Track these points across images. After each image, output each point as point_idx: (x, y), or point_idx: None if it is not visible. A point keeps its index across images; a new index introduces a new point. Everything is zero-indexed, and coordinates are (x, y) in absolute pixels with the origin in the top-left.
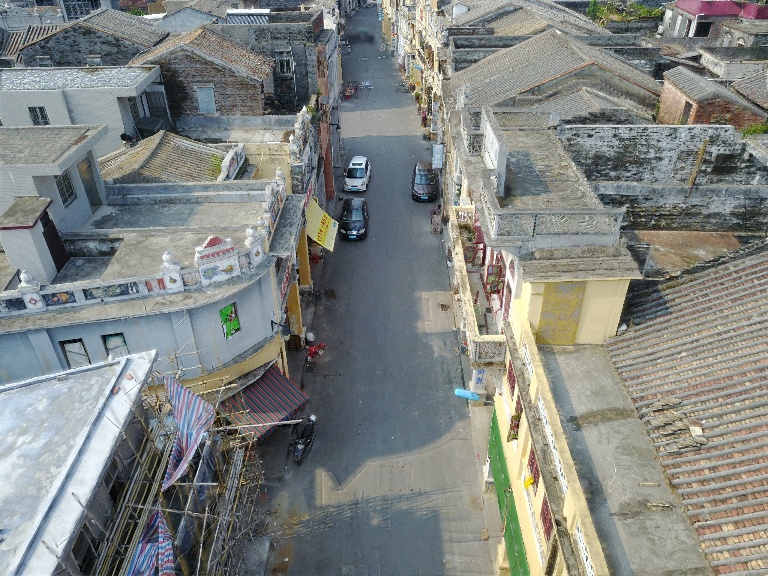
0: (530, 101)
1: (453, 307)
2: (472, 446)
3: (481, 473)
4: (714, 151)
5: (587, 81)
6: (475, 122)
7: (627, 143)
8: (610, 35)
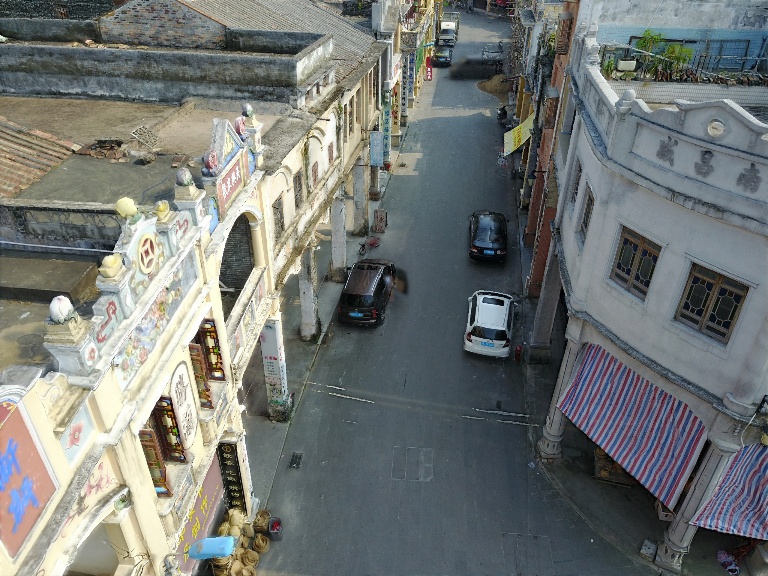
0: None
1: (395, 165)
2: (413, 117)
3: (413, 110)
4: None
5: None
6: None
7: None
8: None
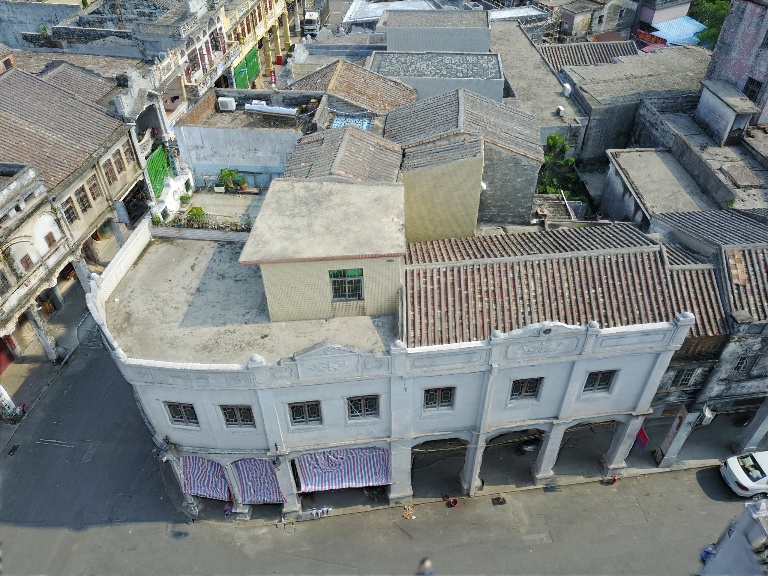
0: None
1: None
2: None
3: None
4: None
5: None
6: (176, 33)
7: None
8: None
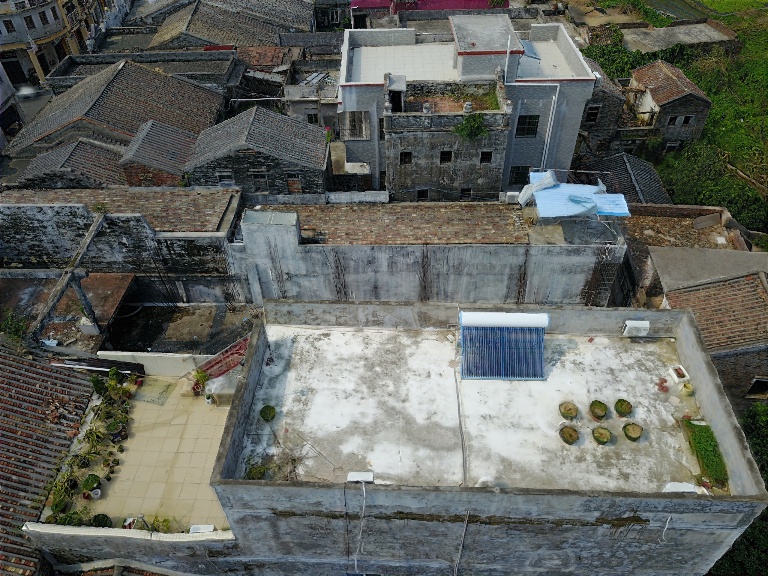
0: (44, 148)
1: None
2: None
3: None
4: (80, 222)
5: (81, 133)
6: None
7: (13, 217)
8: (210, 51)
